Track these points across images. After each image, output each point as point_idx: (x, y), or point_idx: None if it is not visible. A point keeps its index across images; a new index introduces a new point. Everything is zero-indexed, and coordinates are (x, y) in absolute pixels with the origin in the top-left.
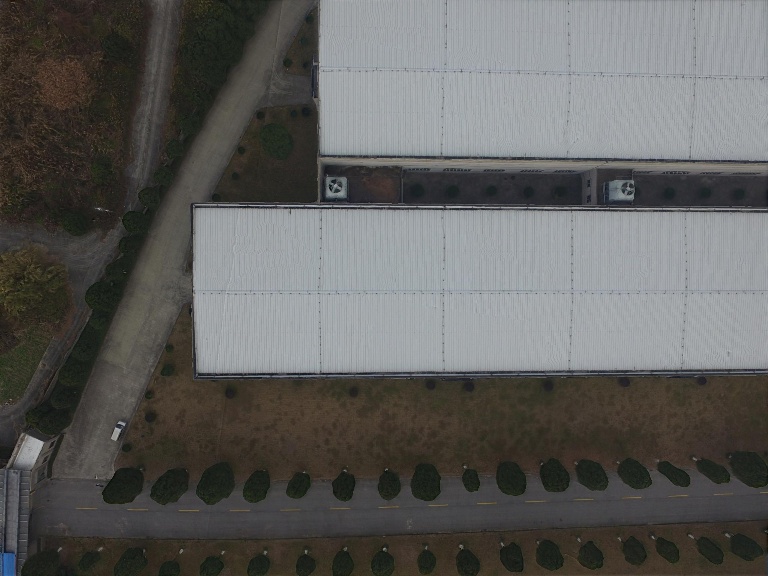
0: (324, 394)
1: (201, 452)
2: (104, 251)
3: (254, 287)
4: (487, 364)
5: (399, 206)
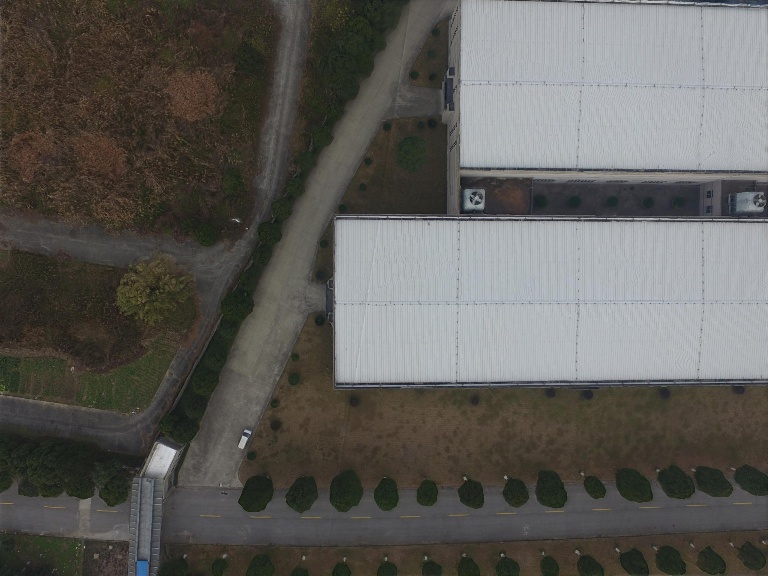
0: (445, 402)
1: (324, 460)
2: (231, 261)
3: (394, 298)
4: (618, 373)
5: (535, 218)
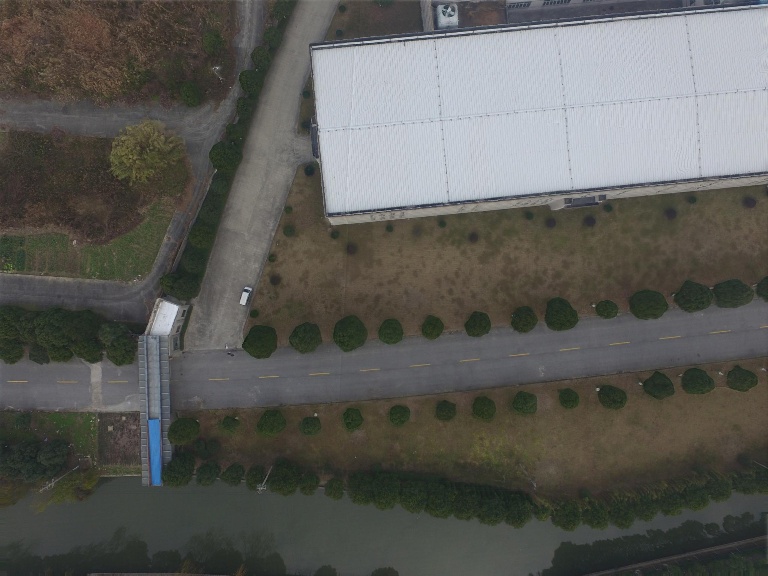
0: (444, 243)
1: (327, 313)
2: (218, 121)
3: (377, 120)
4: (616, 178)
5: (511, 28)
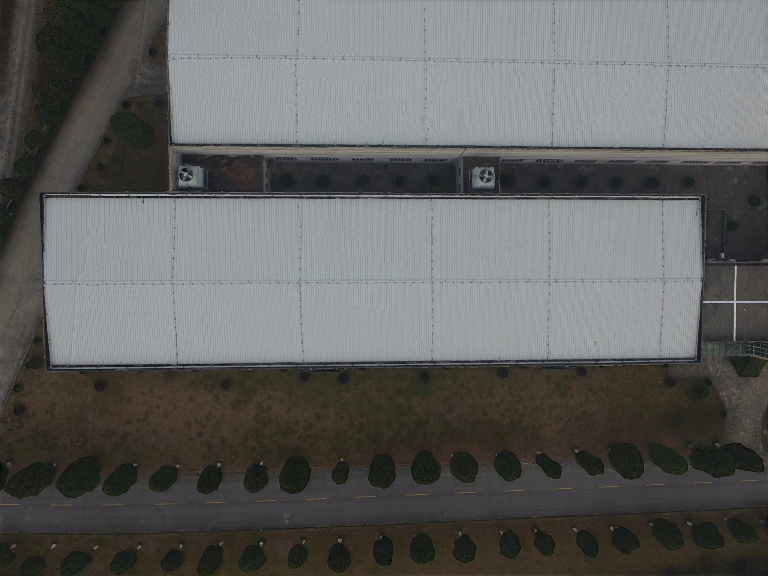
0: (196, 387)
1: (72, 446)
2: None
3: (106, 277)
4: (348, 354)
5: (254, 195)
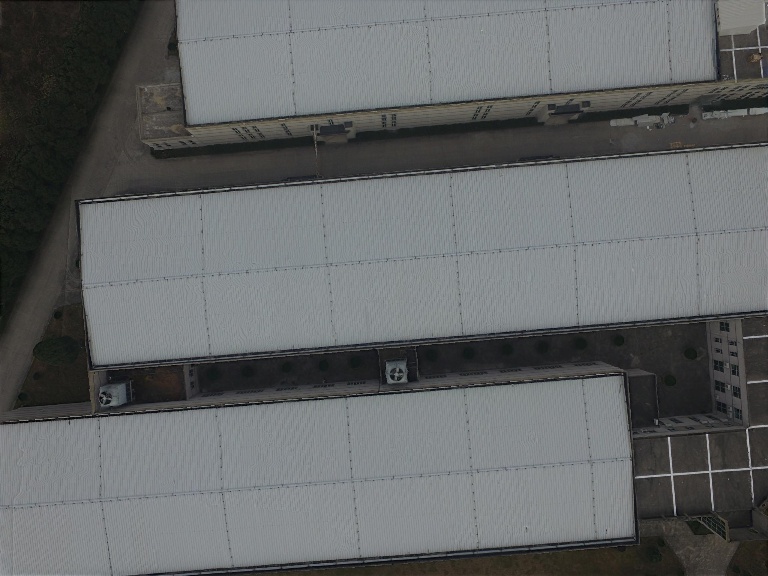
0: None
1: None
2: None
3: (39, 499)
4: (276, 557)
5: (173, 408)
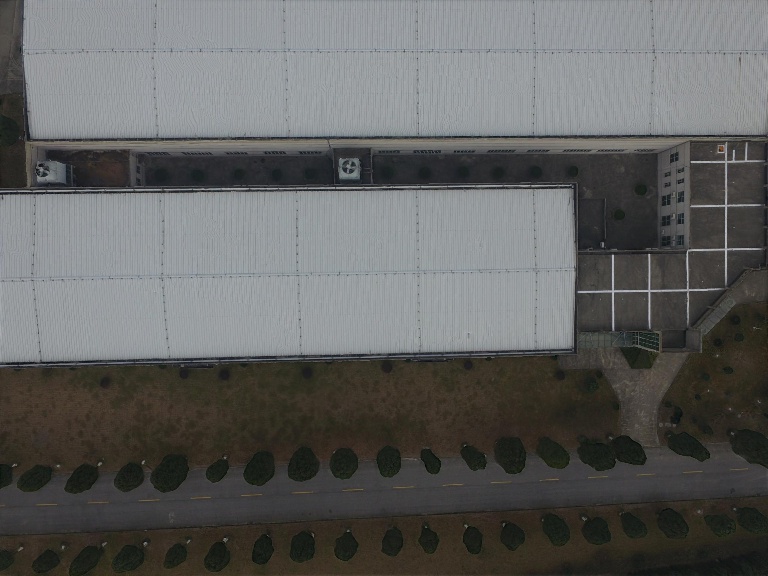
0: (75, 385)
1: None
2: None
3: None
4: (214, 350)
5: (115, 190)
